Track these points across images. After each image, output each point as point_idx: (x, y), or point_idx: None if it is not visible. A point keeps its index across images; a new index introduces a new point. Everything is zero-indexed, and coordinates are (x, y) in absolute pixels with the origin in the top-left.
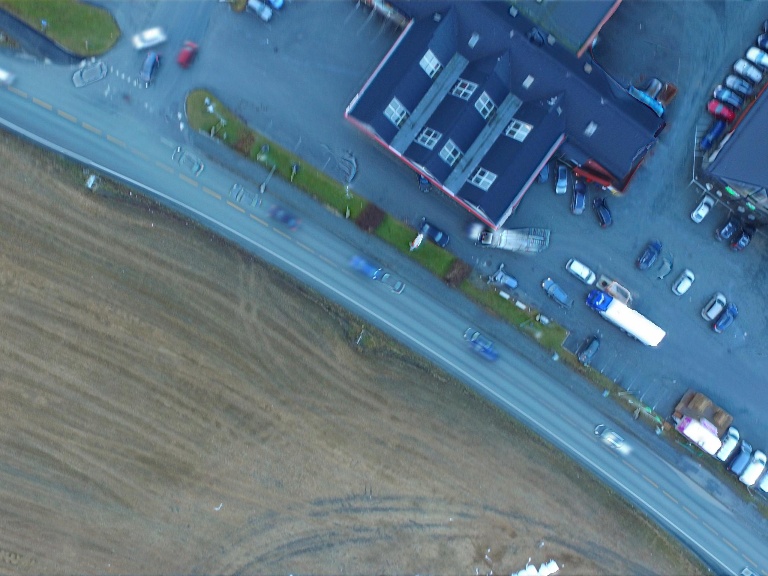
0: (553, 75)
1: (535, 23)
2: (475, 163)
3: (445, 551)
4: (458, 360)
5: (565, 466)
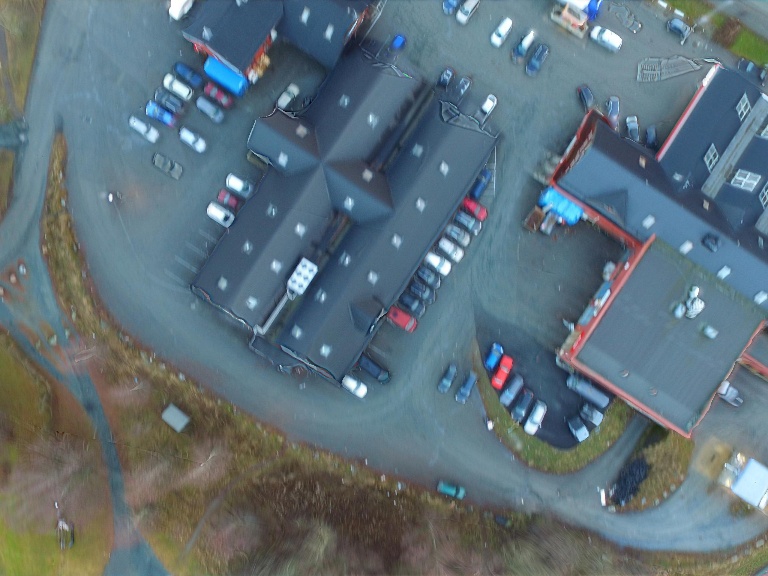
0: (694, 207)
1: (701, 264)
2: (744, 127)
3: None
4: None
5: None
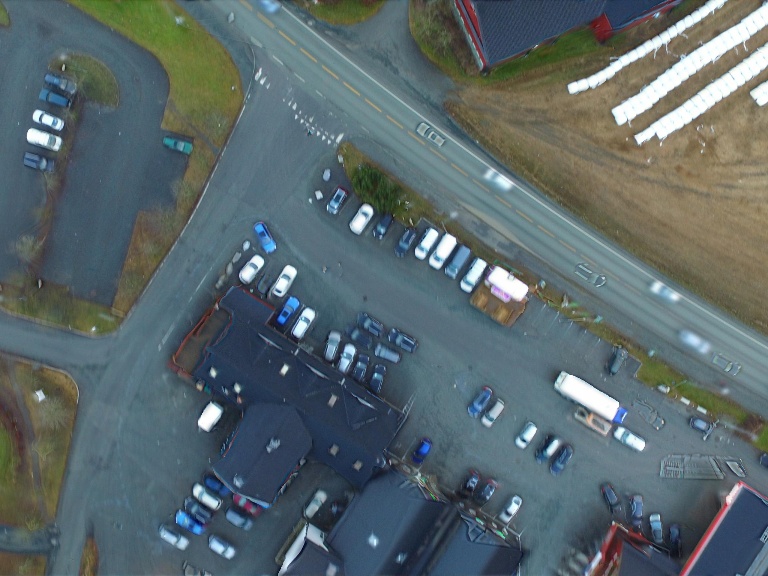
0: None
1: None
2: (767, 545)
3: (746, 149)
4: (746, 343)
5: (632, 242)
